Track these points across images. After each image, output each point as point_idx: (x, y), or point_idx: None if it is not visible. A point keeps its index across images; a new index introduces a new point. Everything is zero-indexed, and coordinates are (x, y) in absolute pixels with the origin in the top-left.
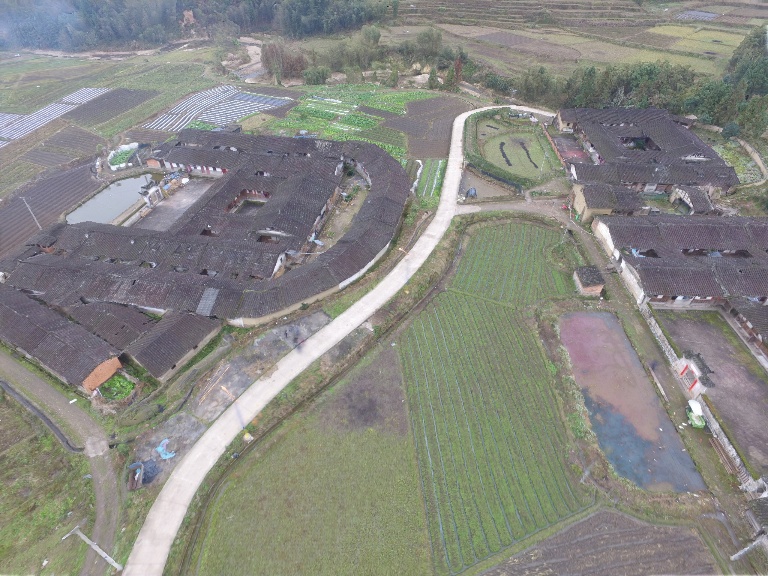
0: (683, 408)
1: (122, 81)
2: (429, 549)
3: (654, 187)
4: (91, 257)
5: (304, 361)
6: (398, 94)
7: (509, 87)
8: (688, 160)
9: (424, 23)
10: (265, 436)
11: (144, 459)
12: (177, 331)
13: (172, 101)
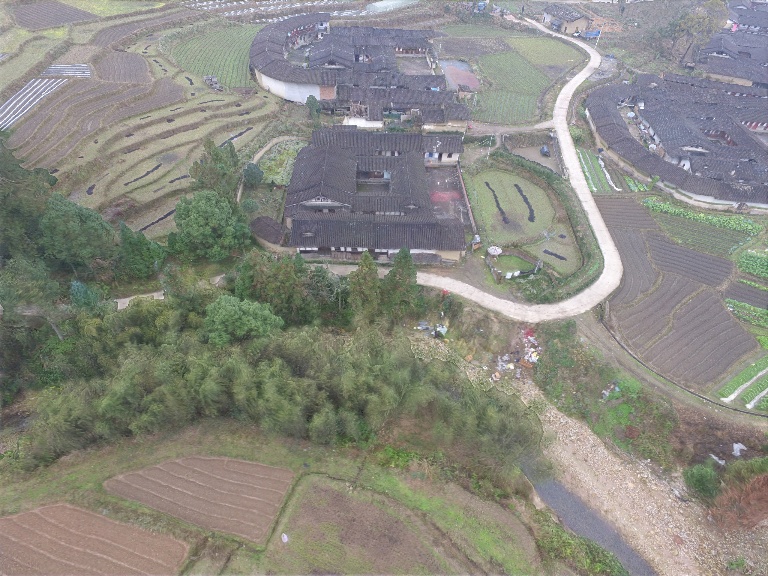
0: (437, 68)
1: None
2: None
3: None
4: None
5: (586, 70)
6: None
7: None
8: None
9: None
10: (581, 62)
11: None
12: None
13: None
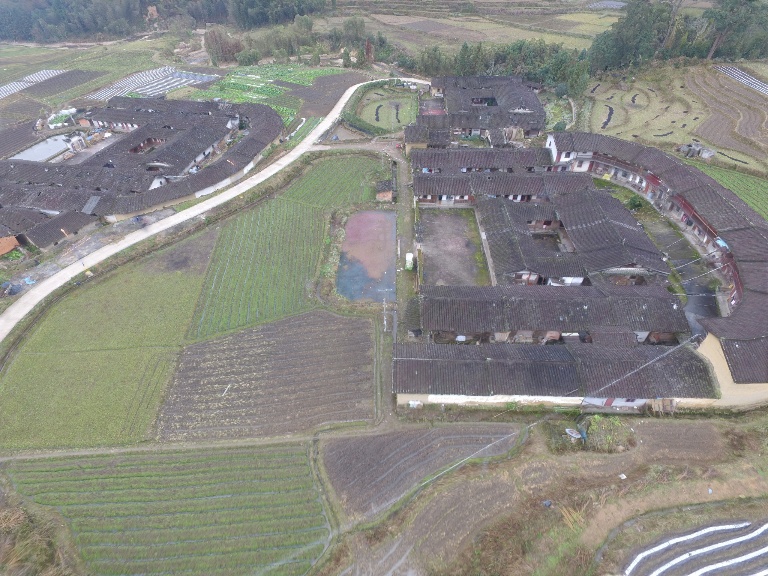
0: None
1: (79, 64)
2: (188, 327)
3: (478, 132)
4: (14, 181)
5: (145, 235)
6: (312, 71)
7: (415, 65)
8: (515, 112)
9: (361, 14)
10: (102, 274)
11: (14, 284)
12: (62, 221)
13: (117, 79)
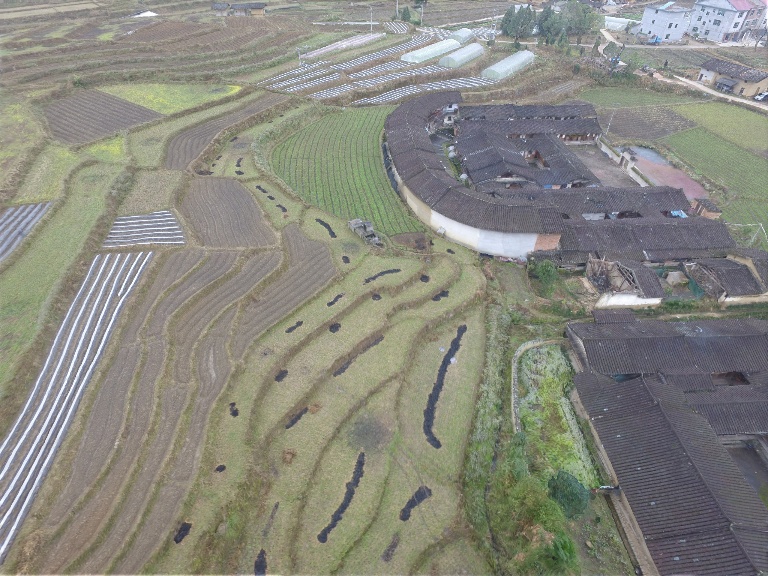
0: None
1: None
2: None
3: None
4: None
5: None
6: None
7: None
8: None
9: None
10: None
11: None
12: None
13: None
